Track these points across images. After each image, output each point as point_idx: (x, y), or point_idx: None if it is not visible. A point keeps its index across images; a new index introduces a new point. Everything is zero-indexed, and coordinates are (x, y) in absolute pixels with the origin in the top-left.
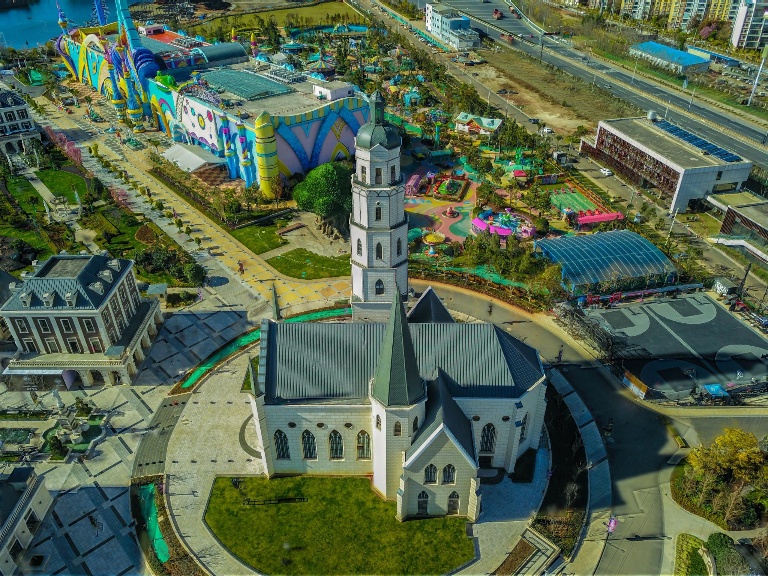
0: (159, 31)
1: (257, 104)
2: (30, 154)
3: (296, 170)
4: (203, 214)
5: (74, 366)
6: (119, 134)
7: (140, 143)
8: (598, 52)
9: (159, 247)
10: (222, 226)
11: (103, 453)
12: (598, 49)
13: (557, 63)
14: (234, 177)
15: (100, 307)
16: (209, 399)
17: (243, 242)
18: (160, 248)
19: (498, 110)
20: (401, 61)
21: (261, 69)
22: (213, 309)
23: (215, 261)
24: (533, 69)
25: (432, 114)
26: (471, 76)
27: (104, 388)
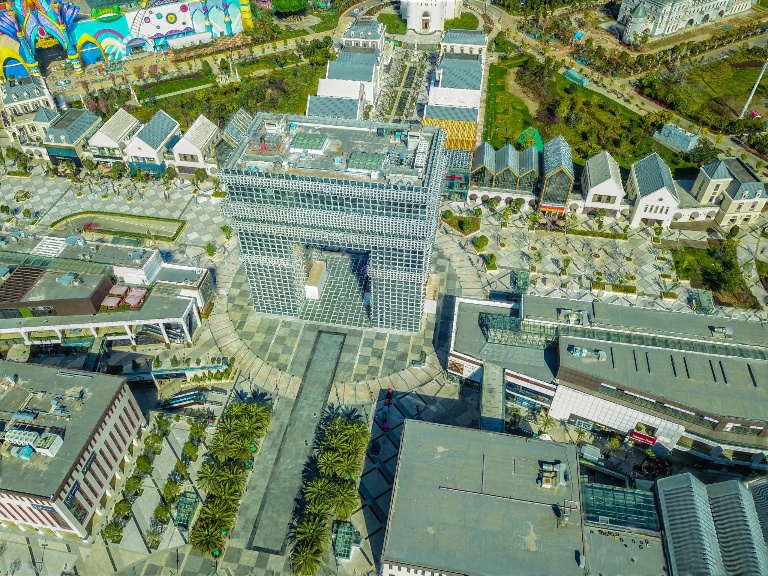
0: None
1: None
2: None
3: None
4: (257, 46)
5: None
6: None
7: None
8: None
9: None
10: (276, 41)
11: None
12: None
13: None
14: None
15: None
16: None
17: (296, 37)
18: None
19: None
20: None
21: None
22: None
23: None
24: None
25: None
26: None
27: None
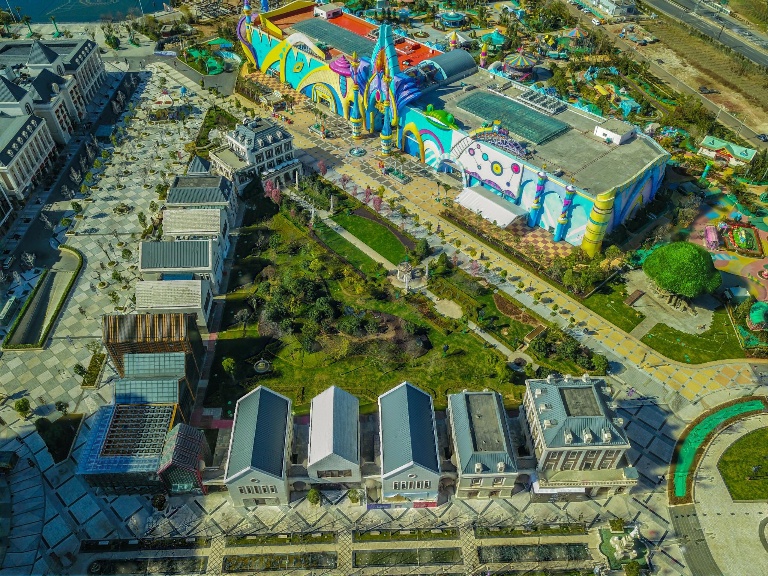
0: (337, 13)
1: (551, 150)
2: (304, 190)
3: (609, 226)
4: (539, 278)
5: (596, 485)
6: (383, 165)
7: (402, 173)
8: (757, 22)
9: (557, 335)
10: (570, 295)
11: (662, 568)
12: (756, 18)
13: (728, 42)
14: (533, 225)
15: (628, 441)
16: (712, 510)
17: (604, 316)
18: (558, 336)
19: (717, 120)
20: (577, 42)
21: (505, 88)
22: (636, 402)
23: (596, 342)
24: (712, 53)
25: (669, 133)
26: (658, 65)
27: (609, 497)
